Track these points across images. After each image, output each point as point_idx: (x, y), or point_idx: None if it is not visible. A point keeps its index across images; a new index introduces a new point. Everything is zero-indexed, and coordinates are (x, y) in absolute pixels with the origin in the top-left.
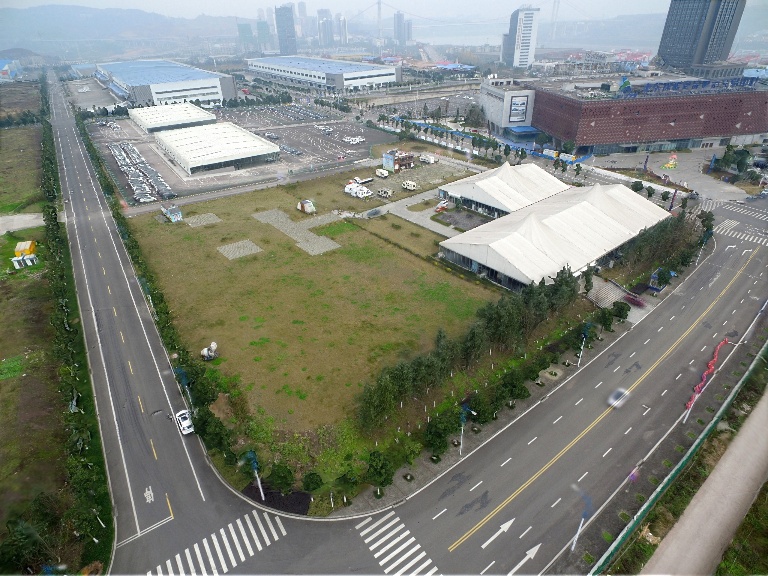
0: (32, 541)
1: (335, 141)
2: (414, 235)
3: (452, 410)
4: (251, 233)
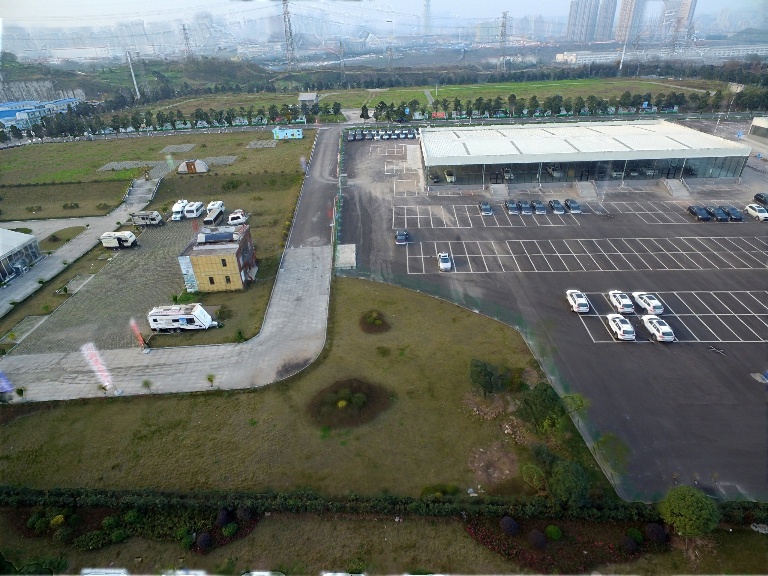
0: None
1: (638, 282)
2: (36, 208)
3: None
4: (197, 153)
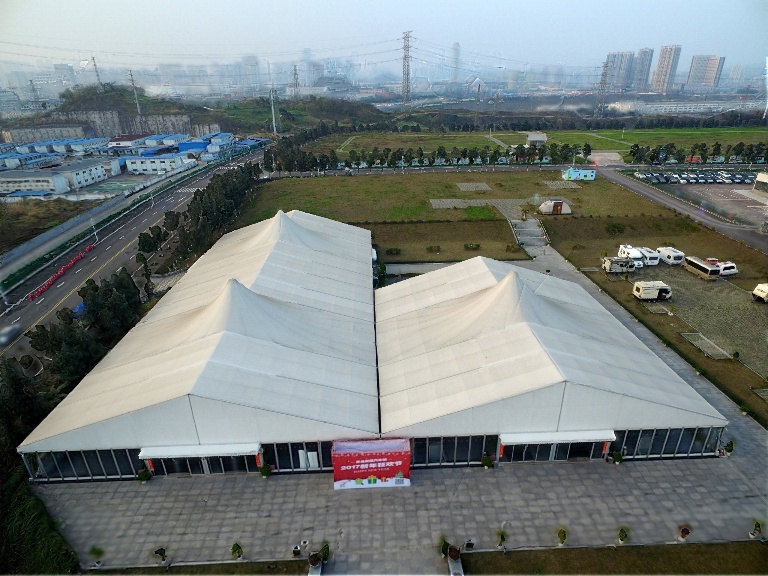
0: None
1: None
2: (434, 248)
3: (217, 180)
4: (508, 192)
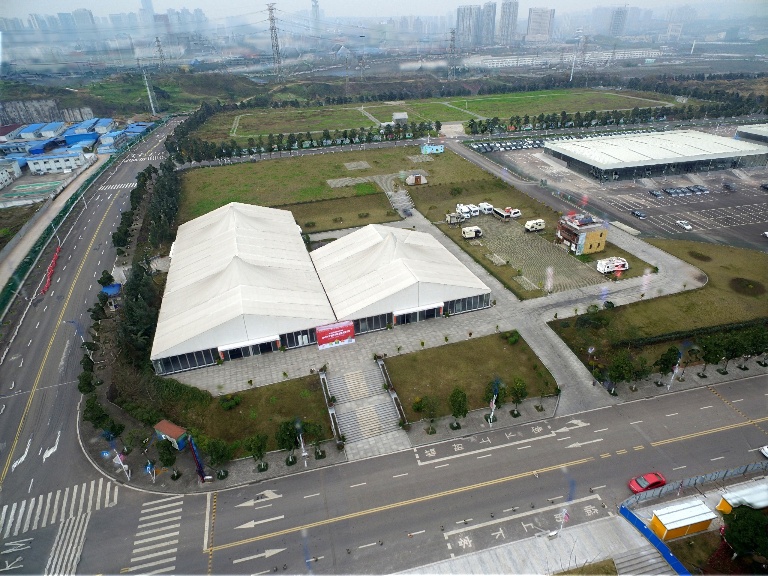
0: (192, 142)
1: None
2: (337, 219)
3: None
4: (383, 168)
